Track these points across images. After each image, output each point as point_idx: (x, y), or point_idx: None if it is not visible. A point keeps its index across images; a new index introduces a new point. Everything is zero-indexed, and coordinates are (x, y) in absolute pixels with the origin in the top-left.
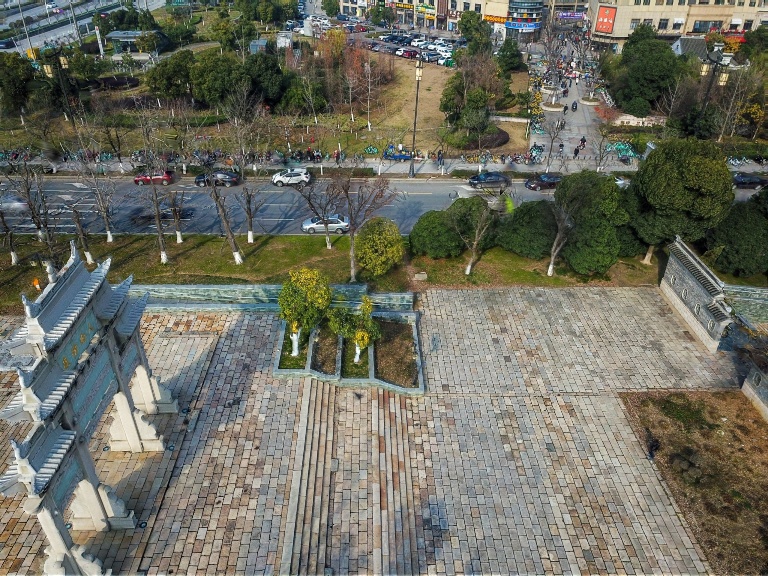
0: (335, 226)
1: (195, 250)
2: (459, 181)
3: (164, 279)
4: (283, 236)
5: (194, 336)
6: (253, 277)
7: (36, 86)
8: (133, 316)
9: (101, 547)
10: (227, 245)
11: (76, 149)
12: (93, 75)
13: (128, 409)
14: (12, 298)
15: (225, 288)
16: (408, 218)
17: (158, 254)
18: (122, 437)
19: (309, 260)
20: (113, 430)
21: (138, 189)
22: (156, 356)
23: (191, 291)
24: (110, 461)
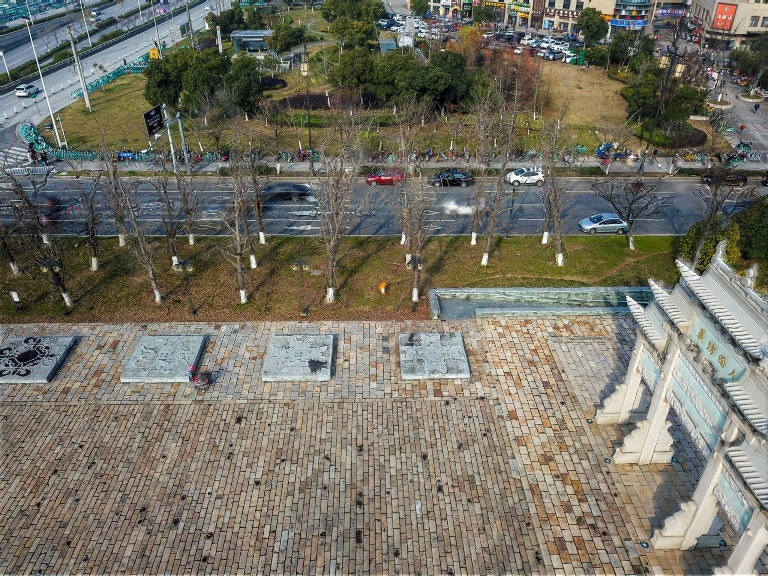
0: (617, 226)
1: (498, 252)
2: (701, 180)
3: (499, 282)
4: (568, 237)
5: (589, 341)
6: (587, 279)
7: (271, 85)
8: None
9: (700, 567)
10: (553, 246)
11: (395, 148)
12: (332, 73)
13: (664, 420)
14: (362, 302)
15: (577, 291)
16: (674, 218)
17: (466, 256)
18: (636, 449)
19: (625, 261)
20: (631, 441)
21: (374, 190)
22: (569, 362)
23: (542, 294)
24: (624, 474)
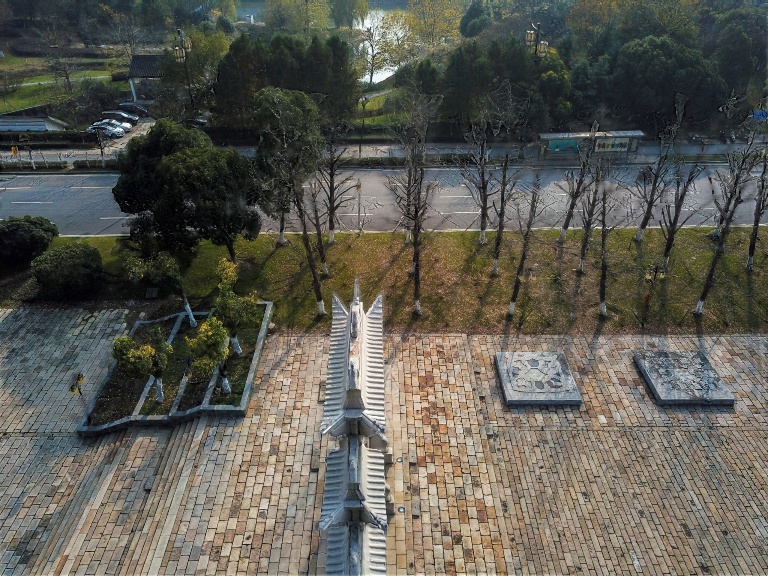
0: None
1: None
2: None
3: None
4: None
5: None
6: None
7: None
8: (337, 567)
9: None
10: None
11: None
12: None
13: None
14: None
15: None
16: None
17: None
18: None
19: None
20: None
21: None
22: None
23: None
24: None
